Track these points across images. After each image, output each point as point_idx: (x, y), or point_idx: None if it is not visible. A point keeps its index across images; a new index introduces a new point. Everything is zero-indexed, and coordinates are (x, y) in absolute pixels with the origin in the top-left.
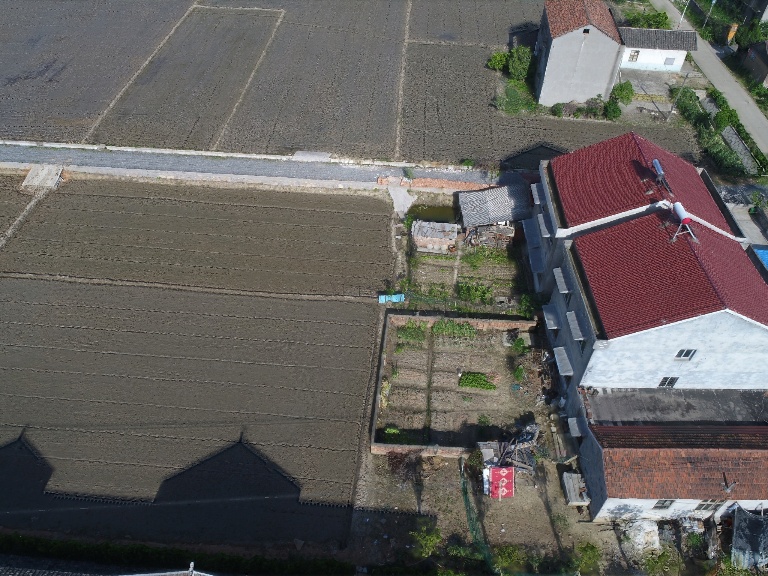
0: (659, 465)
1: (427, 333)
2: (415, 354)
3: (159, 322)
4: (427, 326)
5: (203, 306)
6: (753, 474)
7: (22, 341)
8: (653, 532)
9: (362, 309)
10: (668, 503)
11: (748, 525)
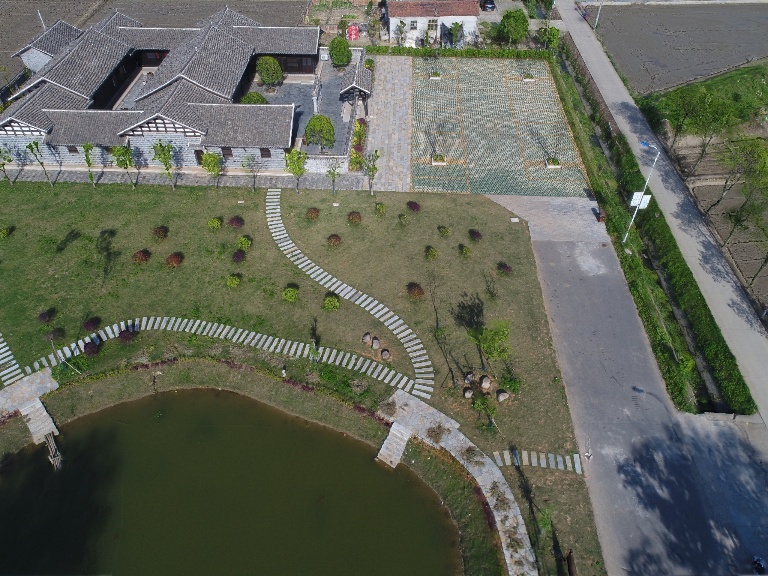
0: (409, 6)
1: (330, 8)
2: (323, 12)
3: (200, 7)
4: (330, 5)
5: (221, 3)
6: (447, 8)
7: (136, 12)
8: (413, 42)
9: (299, 3)
10: (416, 25)
11: (448, 32)
